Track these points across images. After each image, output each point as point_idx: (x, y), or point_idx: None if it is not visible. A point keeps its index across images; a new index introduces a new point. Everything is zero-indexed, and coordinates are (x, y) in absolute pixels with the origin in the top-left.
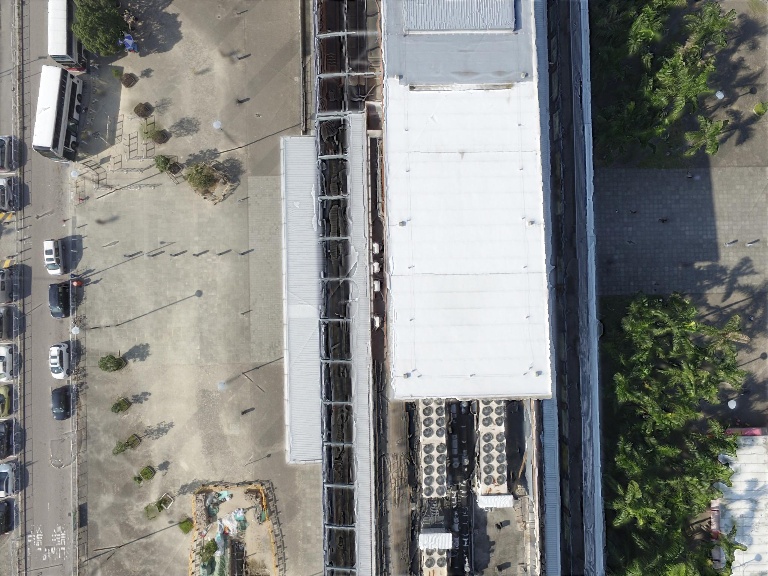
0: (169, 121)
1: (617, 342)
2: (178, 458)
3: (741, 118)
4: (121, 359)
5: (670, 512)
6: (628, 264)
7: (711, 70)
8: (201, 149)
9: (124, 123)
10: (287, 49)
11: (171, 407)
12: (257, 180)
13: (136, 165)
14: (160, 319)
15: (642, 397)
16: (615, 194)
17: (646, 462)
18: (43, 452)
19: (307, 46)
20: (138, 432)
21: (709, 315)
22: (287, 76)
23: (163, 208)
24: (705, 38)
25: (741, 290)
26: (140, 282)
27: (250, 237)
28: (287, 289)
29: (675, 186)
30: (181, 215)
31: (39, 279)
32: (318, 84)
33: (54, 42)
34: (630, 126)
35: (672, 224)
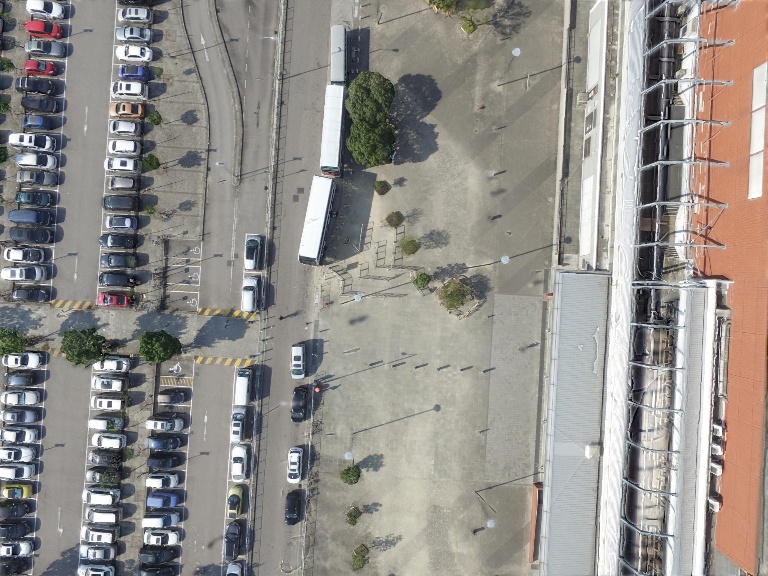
0: (419, 232)
1: None
2: (404, 572)
3: None
4: (356, 468)
5: None
6: None
7: None
8: (449, 263)
9: (374, 230)
10: (543, 169)
11: (401, 520)
12: (504, 298)
13: (383, 274)
14: (396, 430)
15: None
16: None
17: None
18: (270, 555)
19: (565, 168)
20: (366, 542)
21: None
22: (541, 196)
23: (407, 319)
24: None
25: None
26: (379, 392)
27: (492, 355)
28: (554, 426)
29: None
30: (424, 327)
31: (278, 380)
32: (655, 251)
33: (327, 153)
34: None
35: None
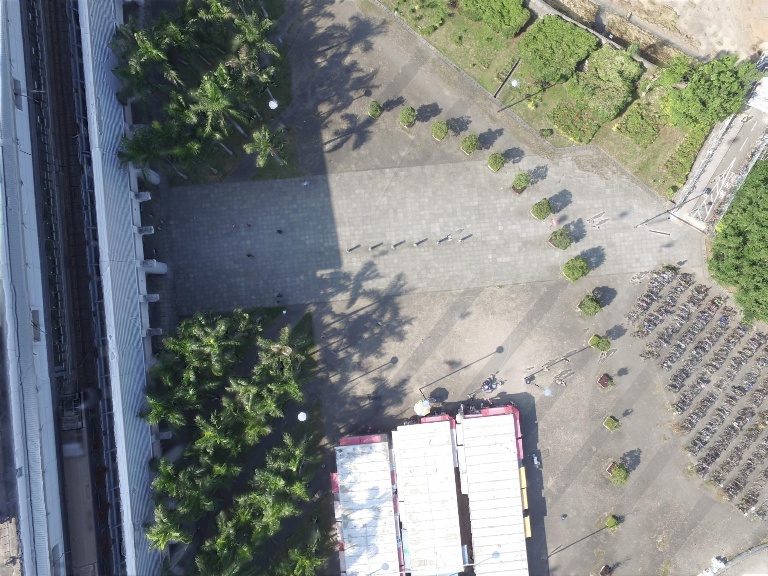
0: None
1: (165, 363)
2: None
3: (357, 122)
4: None
5: (232, 531)
6: (248, 278)
7: (263, 81)
8: None
9: None
10: None
11: None
12: None
13: None
14: None
15: (193, 417)
16: (231, 208)
17: (189, 484)
18: None
19: None
20: None
21: (335, 323)
22: None
23: None
24: (253, 49)
25: (367, 295)
26: None
27: None
28: None
29: (292, 196)
30: None
31: None
32: None
33: None
34: (169, 145)
35: (291, 234)
